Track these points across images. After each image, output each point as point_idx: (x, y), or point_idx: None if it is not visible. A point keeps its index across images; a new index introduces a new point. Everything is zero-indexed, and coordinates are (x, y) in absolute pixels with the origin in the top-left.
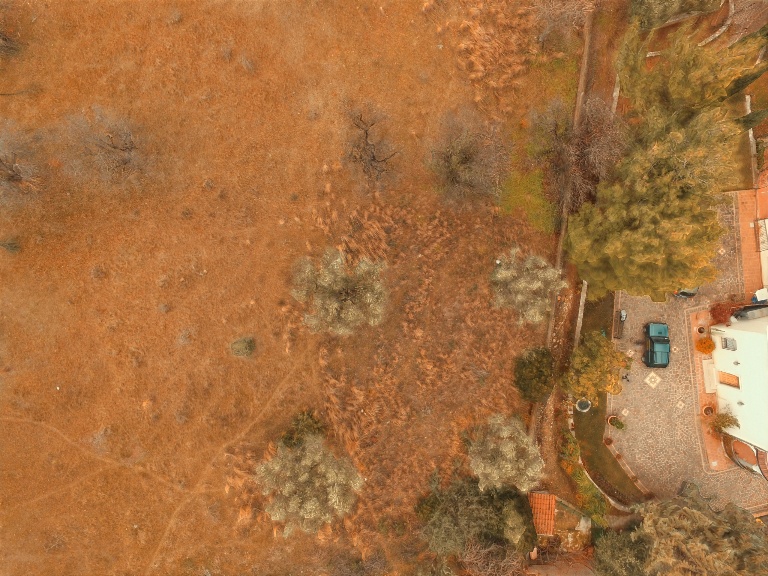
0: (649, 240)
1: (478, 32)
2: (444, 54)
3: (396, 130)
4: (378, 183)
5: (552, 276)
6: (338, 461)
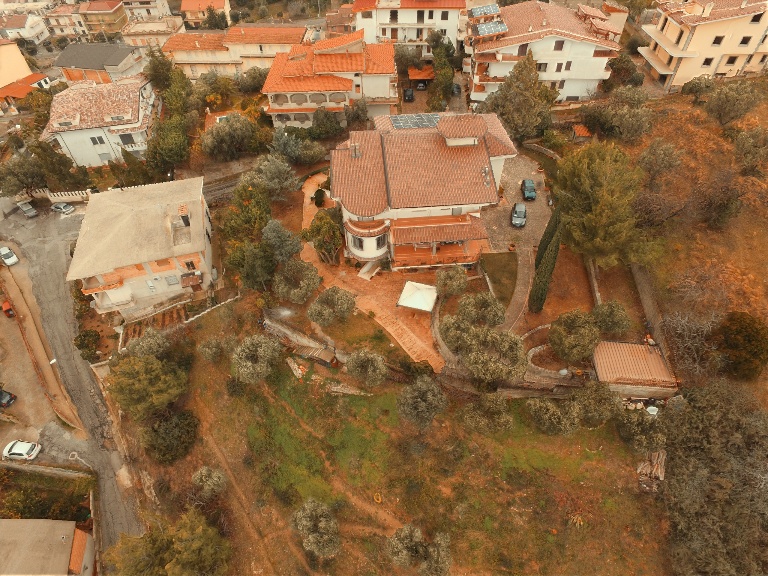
0: (618, 153)
1: (745, 285)
2: (759, 279)
3: (766, 239)
4: (761, 214)
5: (651, 157)
6: (716, 115)
